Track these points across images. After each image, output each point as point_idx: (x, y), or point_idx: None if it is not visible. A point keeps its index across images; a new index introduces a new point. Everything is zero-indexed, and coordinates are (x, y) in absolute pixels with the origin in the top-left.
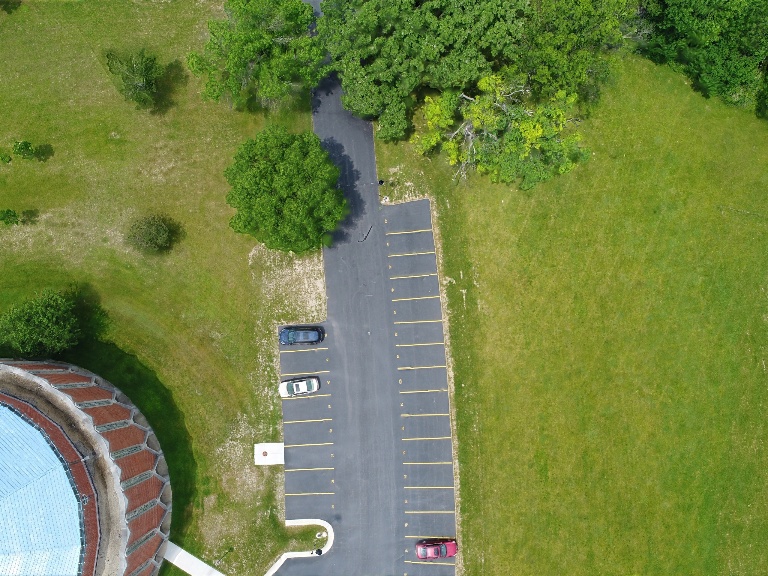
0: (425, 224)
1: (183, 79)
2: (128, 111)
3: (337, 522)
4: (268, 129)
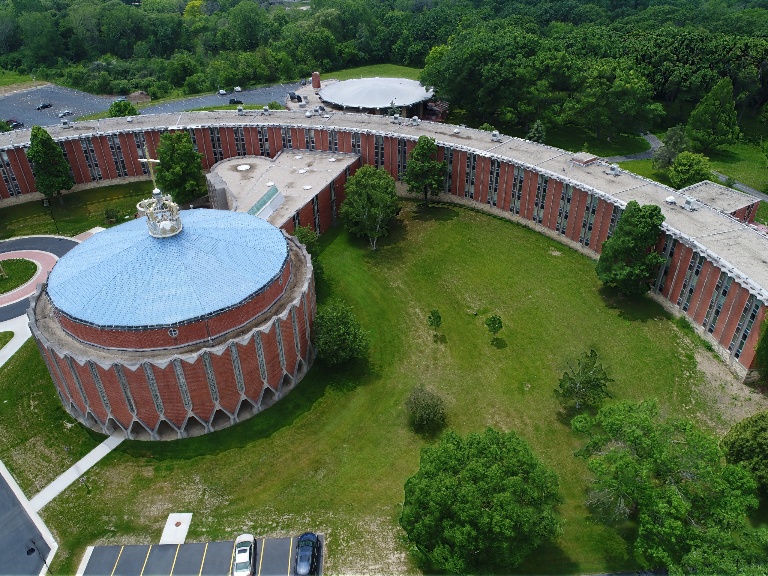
0: None
1: None
2: (555, 395)
3: None
4: None
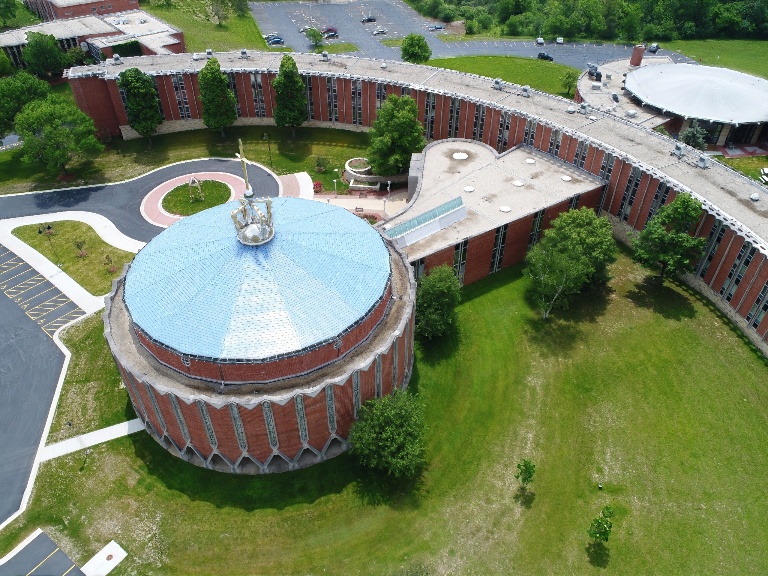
0: None
1: None
2: None
3: None
4: None
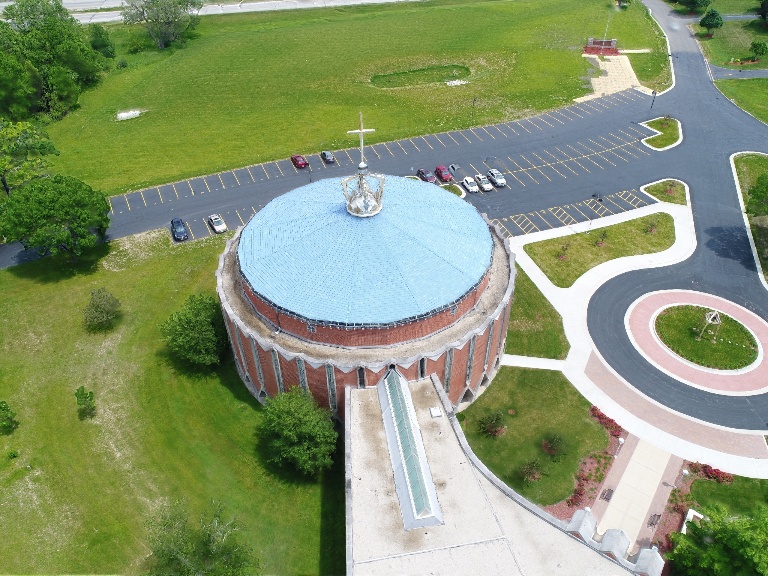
0: None
1: None
2: None
3: None
4: (2, 223)
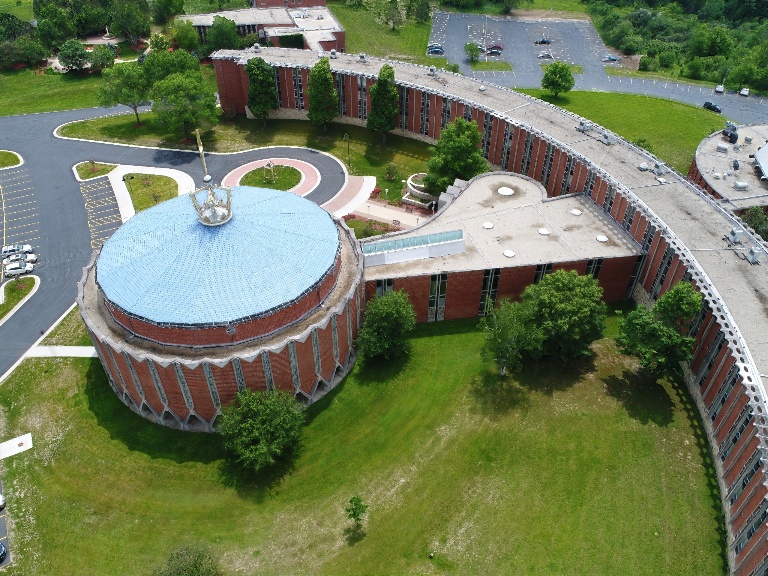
0: None
1: None
2: None
3: None
4: None
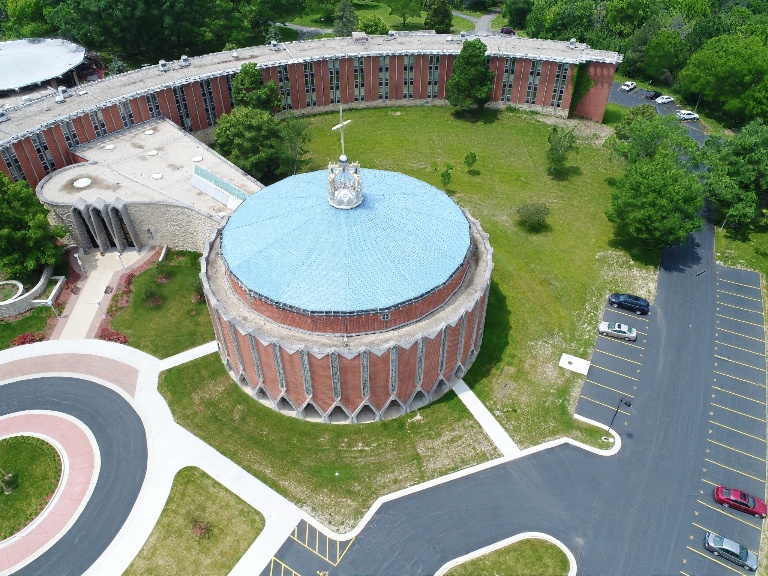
0: (754, 284)
1: (578, 173)
2: (536, 174)
3: (627, 437)
4: None
